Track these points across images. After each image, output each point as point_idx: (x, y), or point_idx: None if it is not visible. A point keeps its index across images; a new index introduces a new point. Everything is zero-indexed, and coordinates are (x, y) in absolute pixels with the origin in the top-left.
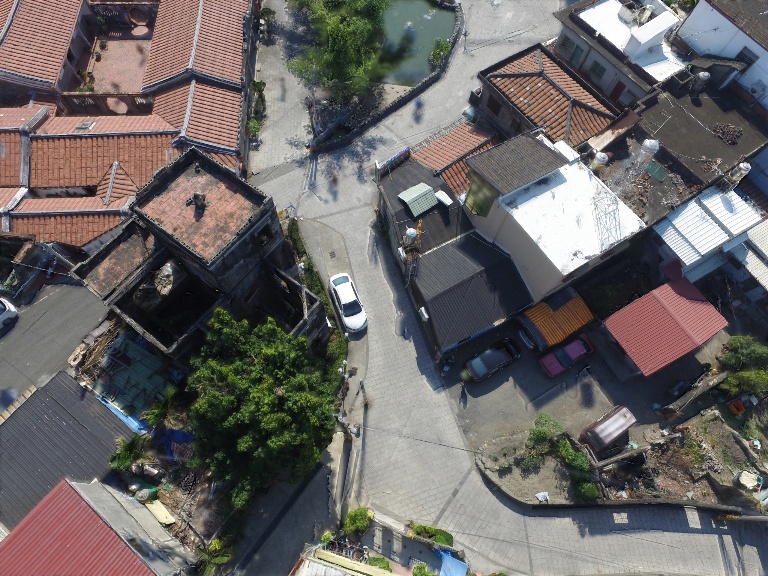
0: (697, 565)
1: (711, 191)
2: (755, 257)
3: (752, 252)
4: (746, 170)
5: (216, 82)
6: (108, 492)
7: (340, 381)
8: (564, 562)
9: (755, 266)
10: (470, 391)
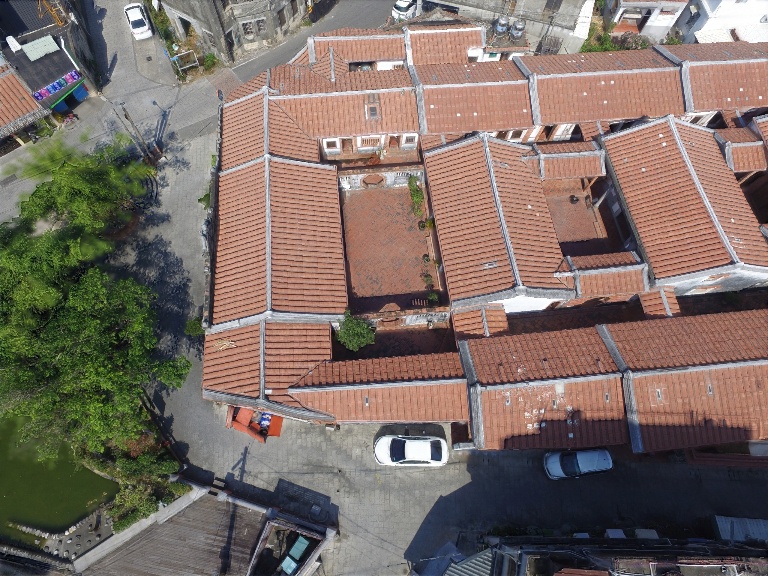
0: None
1: None
2: None
3: None
4: None
5: None
6: None
7: None
8: None
9: None
10: None
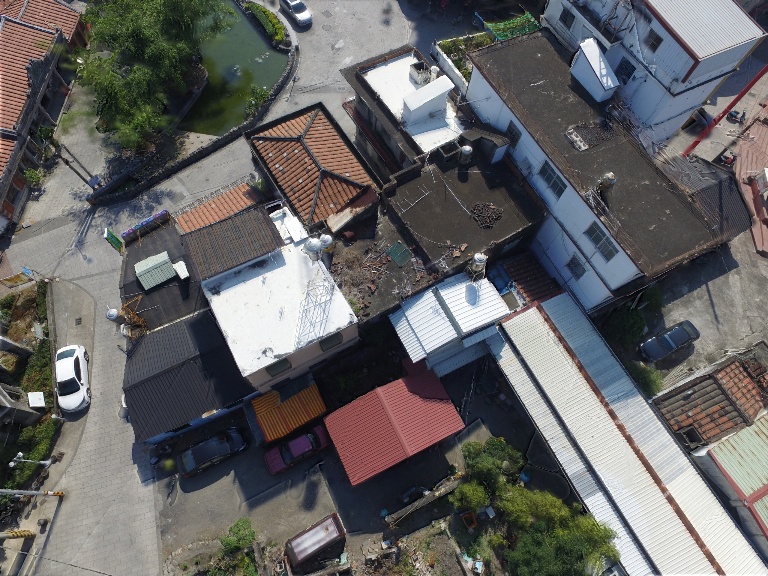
0: None
1: (457, 279)
2: (511, 351)
3: (509, 345)
4: (479, 262)
5: None
6: None
7: (37, 468)
8: None
9: (508, 362)
10: (183, 485)
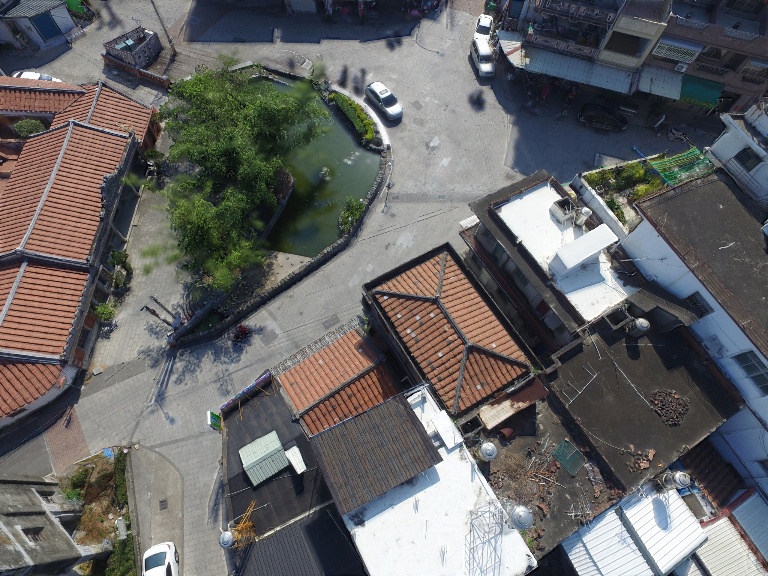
0: None
1: None
2: (700, 574)
3: (696, 566)
4: (683, 486)
5: (56, 262)
6: None
7: None
8: None
9: None
10: None
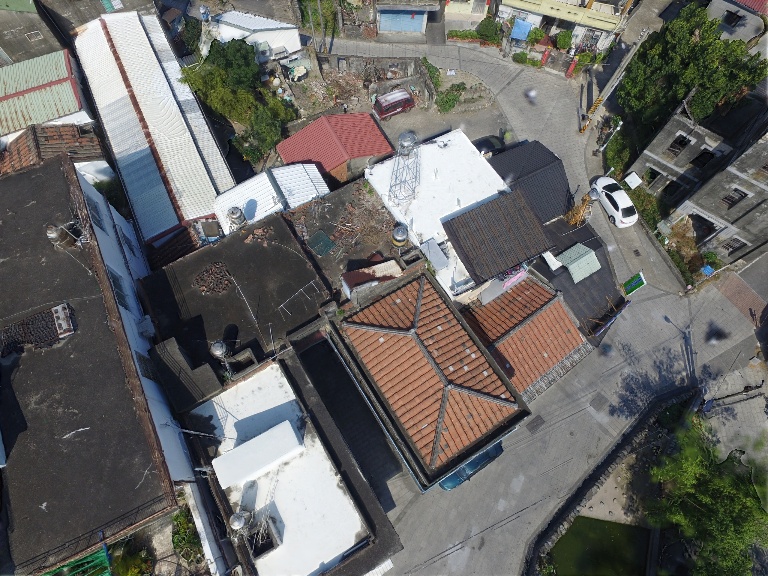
0: (350, 45)
1: None
2: None
3: None
4: (237, 207)
5: None
6: (759, 59)
7: None
8: (437, 51)
9: (226, 186)
10: None
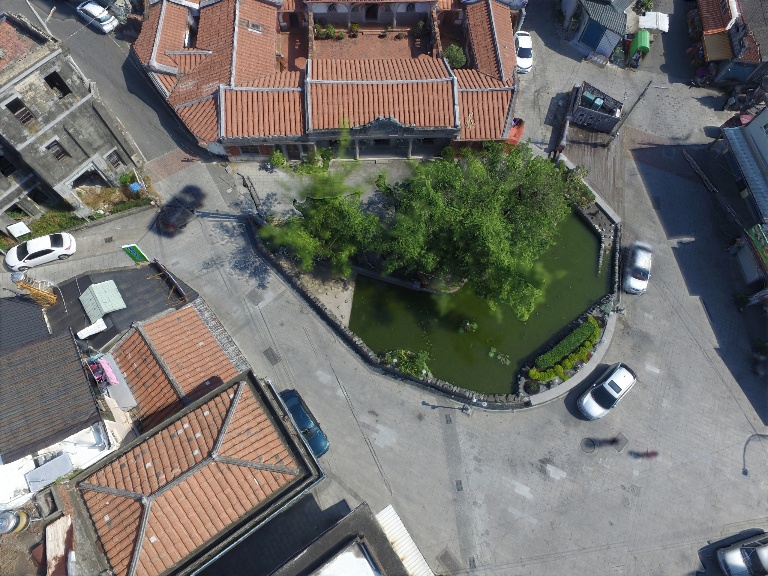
0: None
1: None
2: None
3: None
4: None
5: None
6: None
7: None
8: None
9: None
10: None
